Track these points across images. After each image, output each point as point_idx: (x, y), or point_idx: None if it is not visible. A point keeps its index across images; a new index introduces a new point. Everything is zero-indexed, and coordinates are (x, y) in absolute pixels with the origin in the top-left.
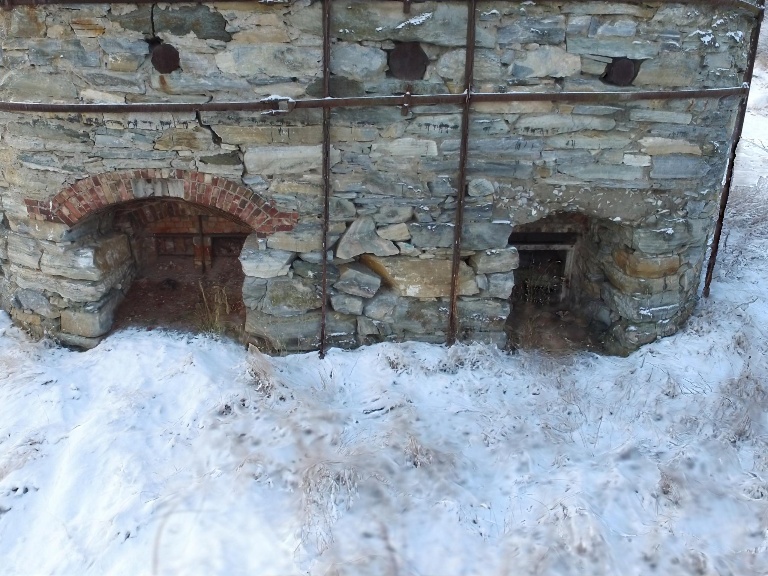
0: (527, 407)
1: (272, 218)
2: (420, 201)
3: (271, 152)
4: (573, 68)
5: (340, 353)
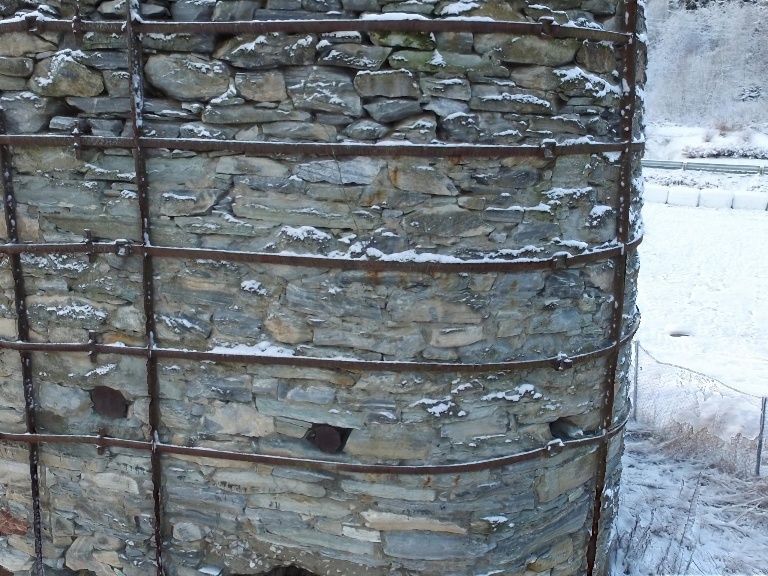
0: None
1: (8, 521)
2: (126, 535)
3: (5, 464)
4: (265, 429)
5: None
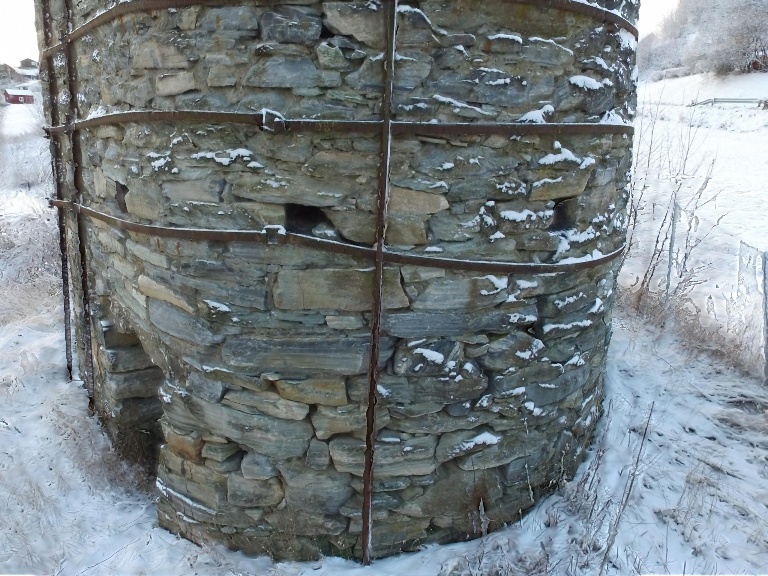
0: (27, 485)
1: None
2: None
3: None
4: None
5: (72, 385)
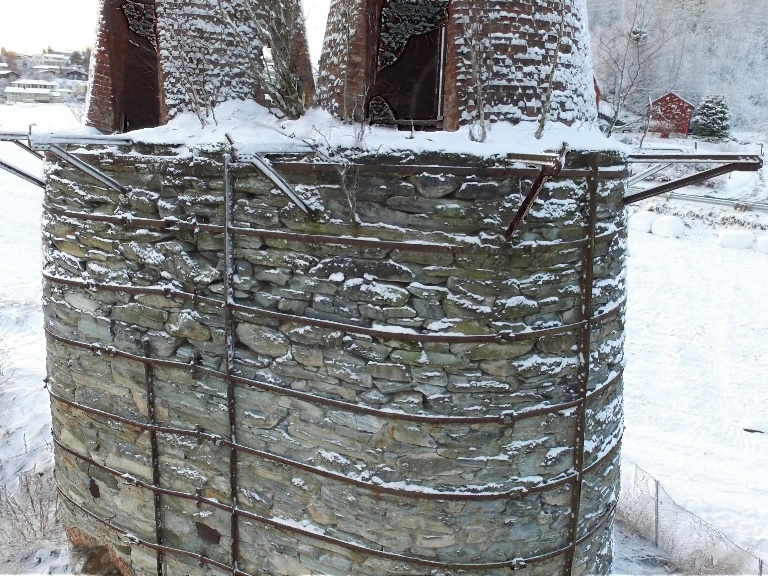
0: None
1: None
2: None
3: (142, 555)
4: None
5: None
